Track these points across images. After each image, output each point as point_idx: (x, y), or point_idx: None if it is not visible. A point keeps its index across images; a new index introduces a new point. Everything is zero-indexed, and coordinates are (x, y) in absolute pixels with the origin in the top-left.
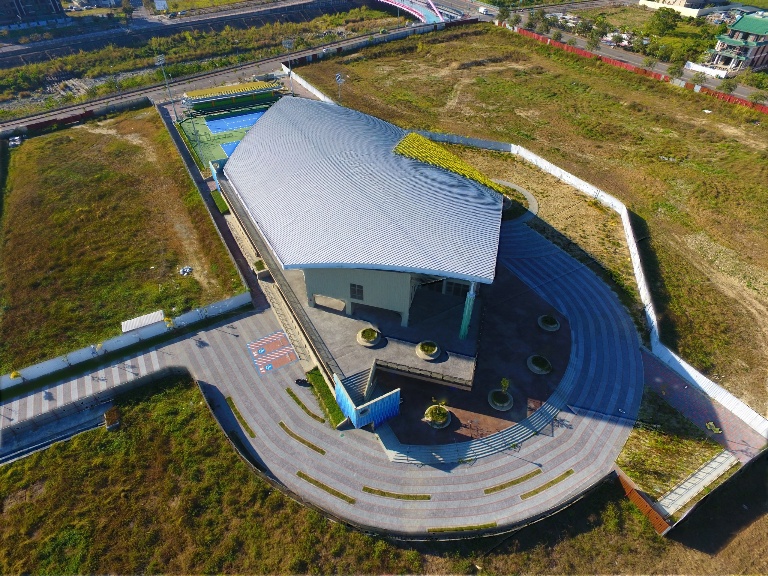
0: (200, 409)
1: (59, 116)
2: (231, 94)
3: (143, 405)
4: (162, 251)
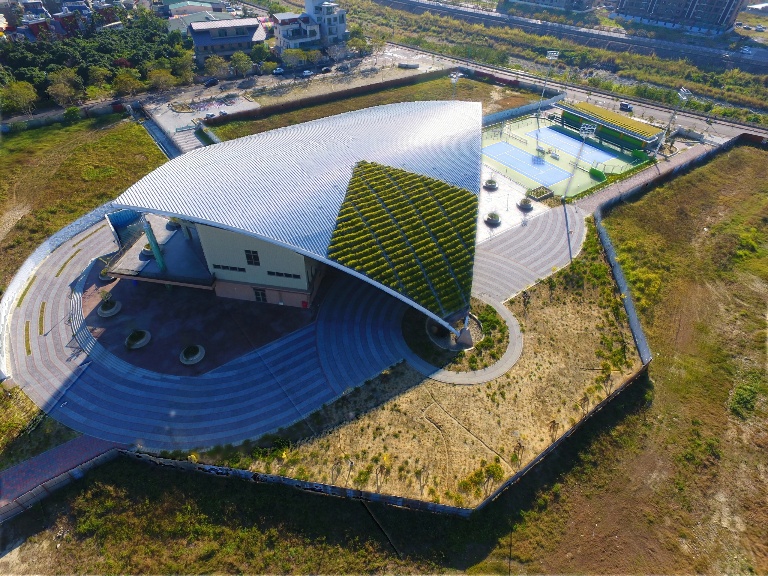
0: None
1: (509, 77)
2: (596, 118)
3: None
4: None
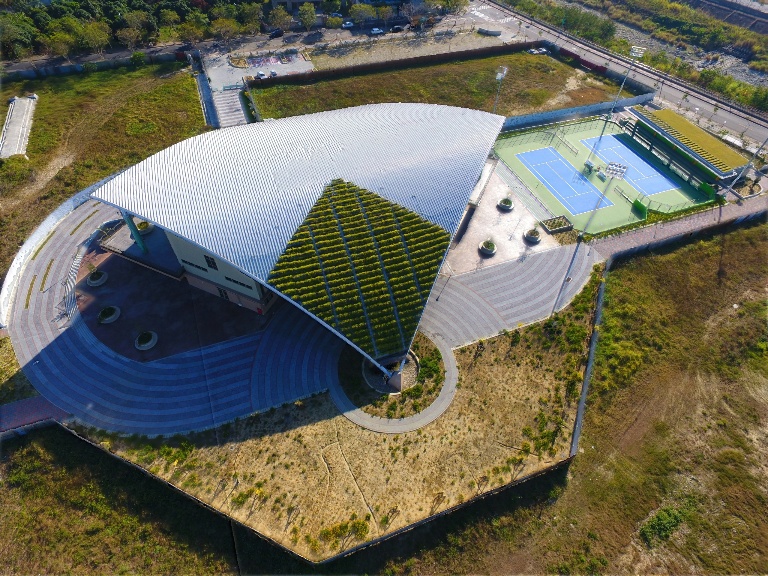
0: None
1: (601, 60)
2: (671, 135)
3: None
4: None
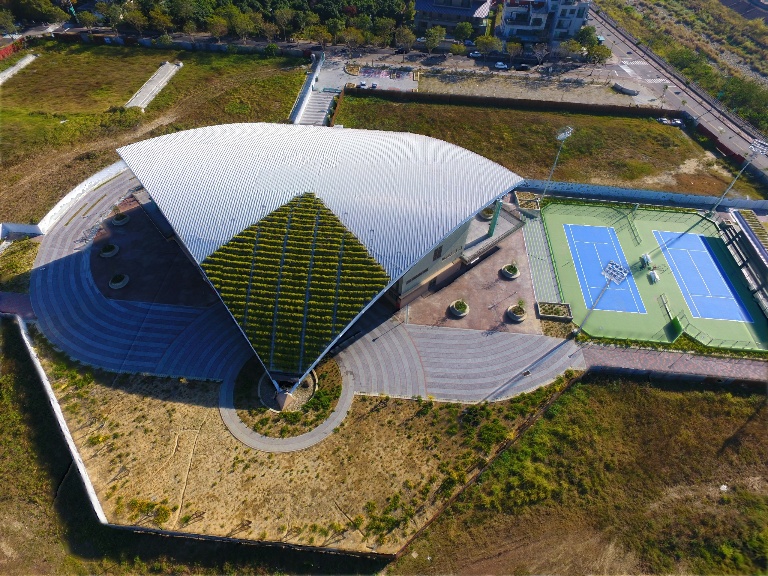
0: None
1: None
2: None
3: None
4: None
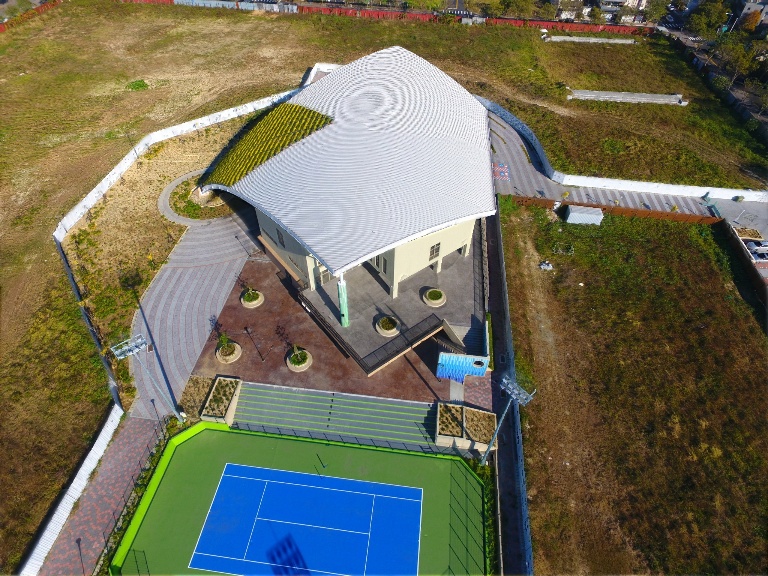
0: (548, 161)
1: None
2: None
3: (582, 175)
4: (571, 298)
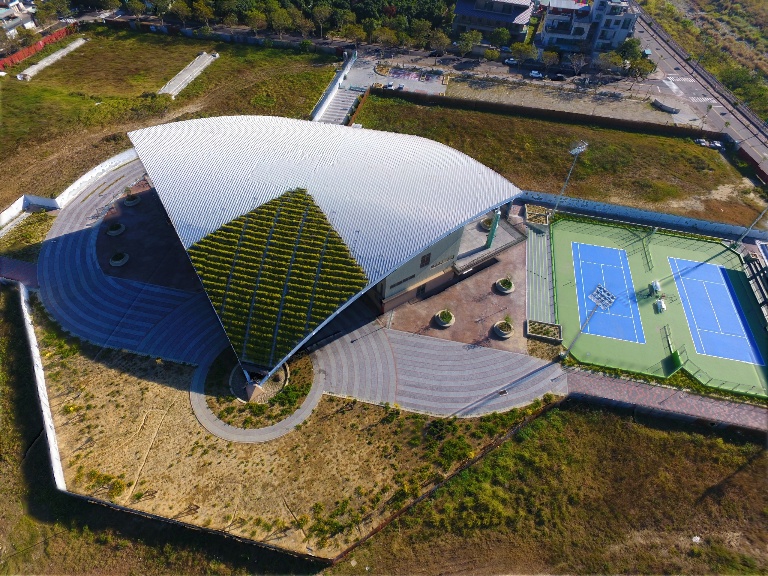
0: None
1: None
2: None
3: None
4: None
